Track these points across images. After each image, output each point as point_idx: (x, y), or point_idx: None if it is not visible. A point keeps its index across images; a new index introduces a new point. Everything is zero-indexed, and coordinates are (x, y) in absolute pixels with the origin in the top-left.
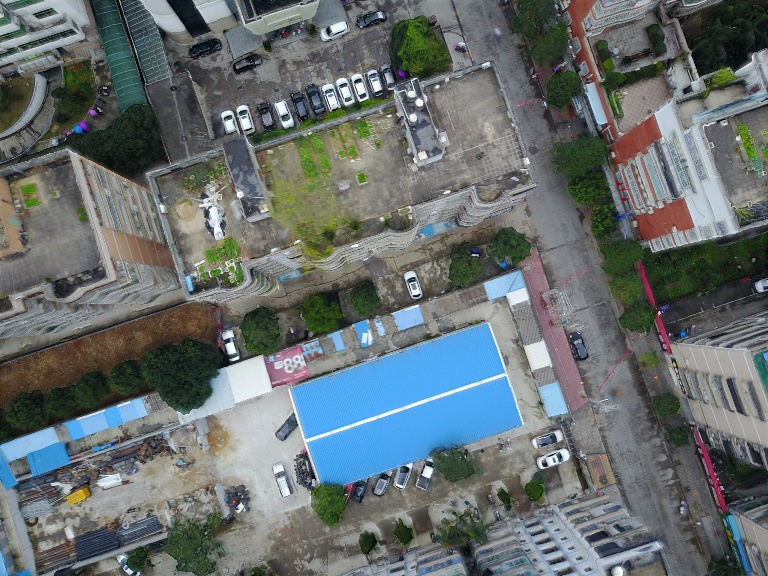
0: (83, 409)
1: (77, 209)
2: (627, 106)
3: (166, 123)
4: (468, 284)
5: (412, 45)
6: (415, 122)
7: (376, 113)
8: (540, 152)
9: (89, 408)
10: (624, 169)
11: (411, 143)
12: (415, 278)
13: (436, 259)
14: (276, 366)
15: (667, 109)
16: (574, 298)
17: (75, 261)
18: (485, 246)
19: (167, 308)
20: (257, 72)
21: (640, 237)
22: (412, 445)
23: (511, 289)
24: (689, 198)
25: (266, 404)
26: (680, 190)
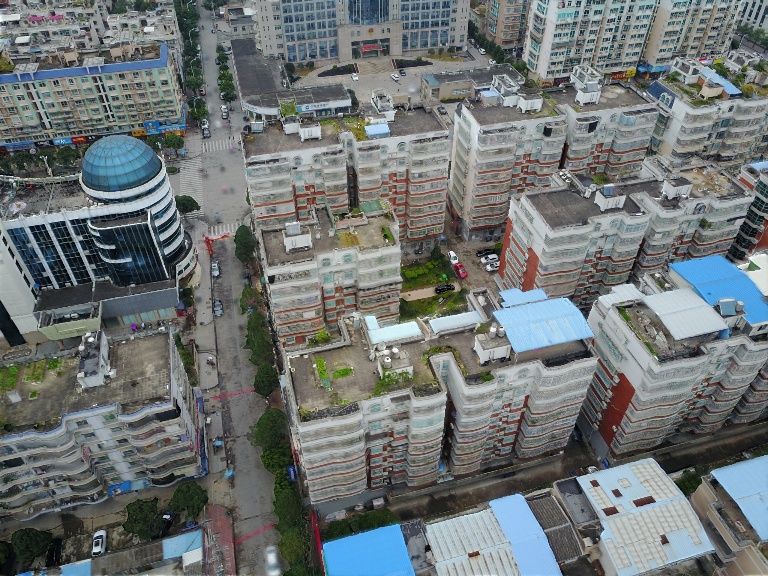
0: None
1: None
2: None
3: None
4: (146, 539)
5: None
6: (84, 353)
7: (69, 355)
8: None
9: None
10: None
11: None
12: (102, 536)
13: None
14: None
15: None
16: (257, 569)
17: None
18: (183, 512)
19: None
20: None
21: (308, 495)
22: None
23: (189, 549)
24: None
25: None
26: (293, 419)
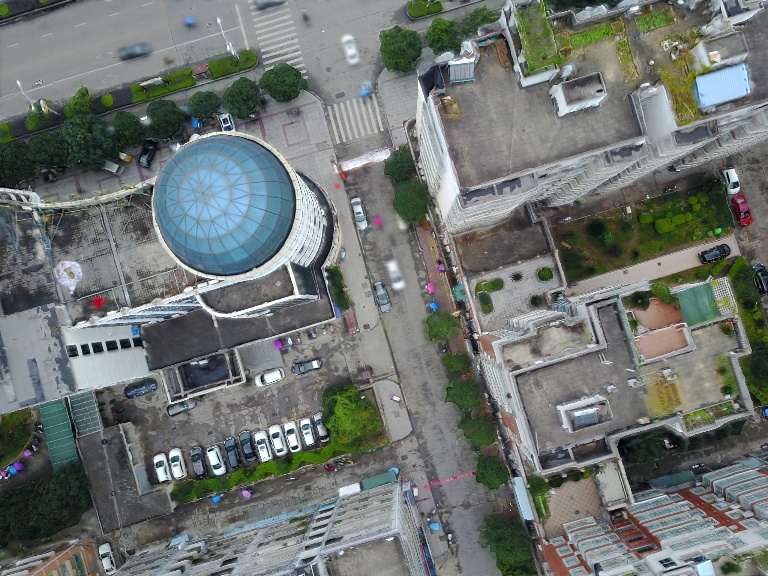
0: None
1: None
2: (554, 505)
3: (96, 477)
4: None
5: (339, 423)
6: None
7: None
8: (474, 507)
9: None
10: (548, 575)
11: None
12: None
13: None
14: None
15: None
16: None
17: None
18: None
19: None
20: (191, 413)
21: None
22: None
23: None
24: None
25: None
26: None
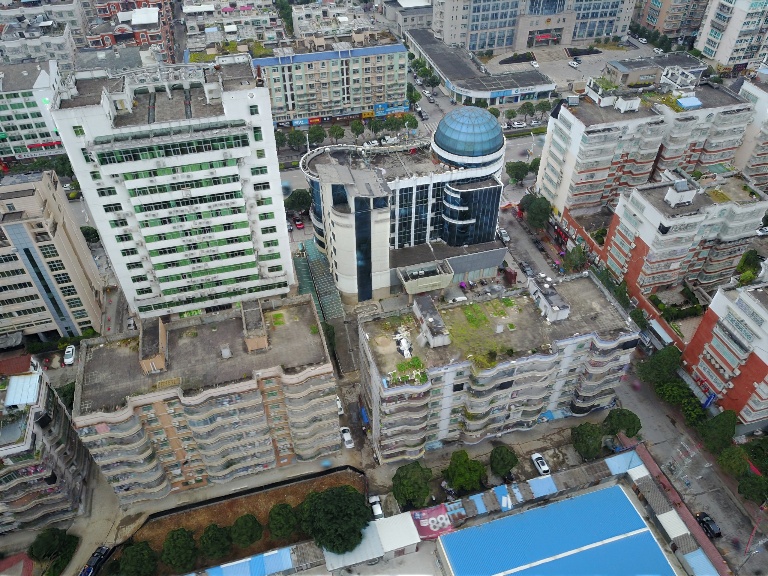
0: (229, 556)
1: (310, 327)
2: (684, 332)
3: (338, 341)
4: (591, 458)
5: None
6: (547, 290)
7: (516, 295)
8: (624, 377)
9: (234, 558)
10: (698, 366)
11: (545, 304)
12: (542, 458)
13: (557, 447)
14: (422, 523)
15: (717, 296)
16: None
17: (304, 357)
18: None
19: (320, 474)
20: None
21: None
22: None
23: (630, 466)
24: (757, 349)
25: (408, 569)
26: (748, 345)
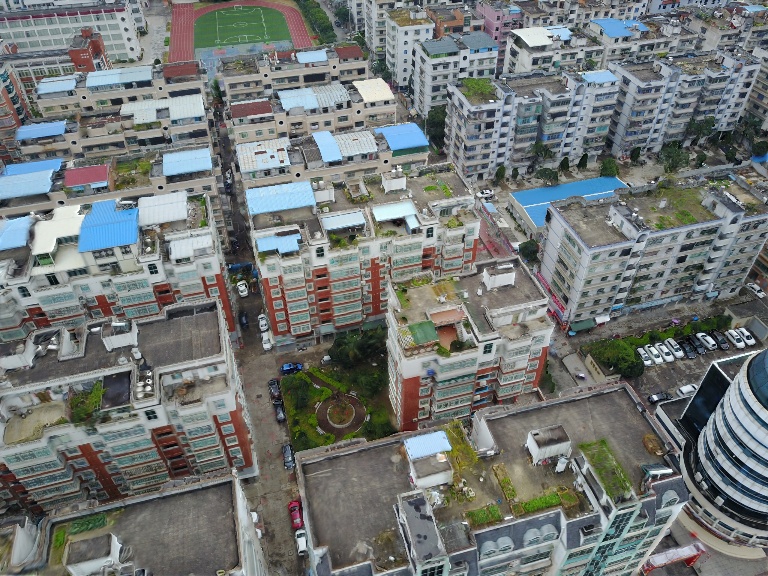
0: None
1: None
2: None
3: None
4: None
5: None
6: None
7: None
8: None
9: None
10: None
11: None
12: None
13: None
14: None
15: None
16: (477, 253)
17: None
18: None
19: None
20: None
21: None
22: (569, 188)
23: None
24: None
25: None
26: None
